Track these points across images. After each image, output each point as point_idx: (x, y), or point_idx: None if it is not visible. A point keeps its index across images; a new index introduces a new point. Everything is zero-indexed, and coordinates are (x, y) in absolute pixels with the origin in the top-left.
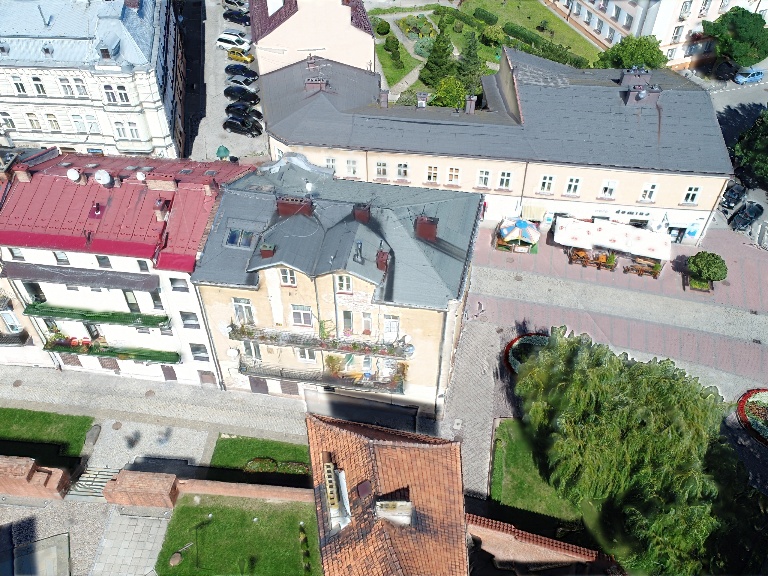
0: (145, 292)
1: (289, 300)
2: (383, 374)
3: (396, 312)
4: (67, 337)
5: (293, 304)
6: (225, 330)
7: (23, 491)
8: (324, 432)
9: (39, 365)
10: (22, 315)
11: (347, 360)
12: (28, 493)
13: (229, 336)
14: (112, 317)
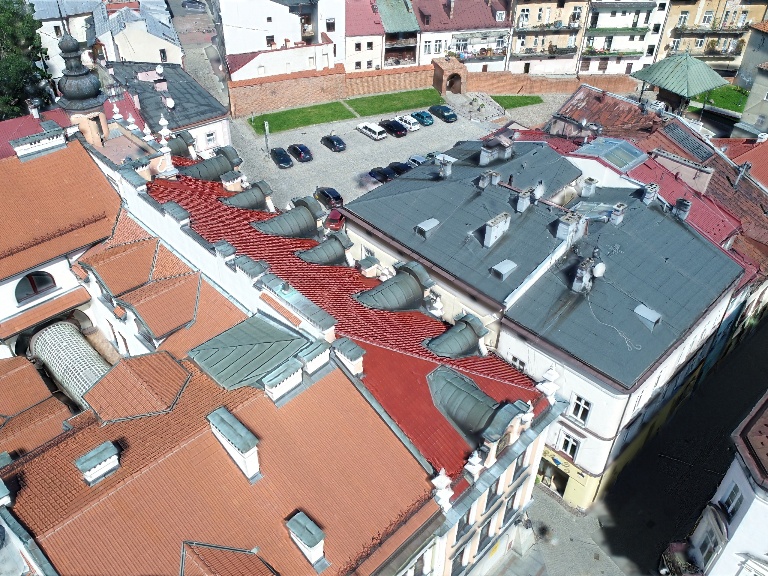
0: (645, 13)
1: (706, 8)
2: (729, 50)
3: (748, 8)
4: (594, 49)
5: (707, 11)
6: (669, 33)
7: (621, 89)
8: (764, 23)
9: (568, 73)
10: (579, 37)
11: (719, 42)
12: (623, 90)
13: (677, 31)
14: (628, 28)
